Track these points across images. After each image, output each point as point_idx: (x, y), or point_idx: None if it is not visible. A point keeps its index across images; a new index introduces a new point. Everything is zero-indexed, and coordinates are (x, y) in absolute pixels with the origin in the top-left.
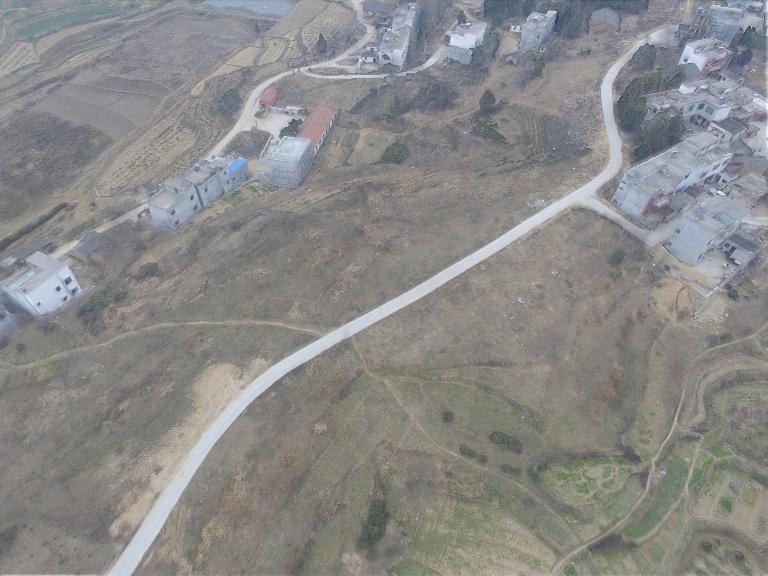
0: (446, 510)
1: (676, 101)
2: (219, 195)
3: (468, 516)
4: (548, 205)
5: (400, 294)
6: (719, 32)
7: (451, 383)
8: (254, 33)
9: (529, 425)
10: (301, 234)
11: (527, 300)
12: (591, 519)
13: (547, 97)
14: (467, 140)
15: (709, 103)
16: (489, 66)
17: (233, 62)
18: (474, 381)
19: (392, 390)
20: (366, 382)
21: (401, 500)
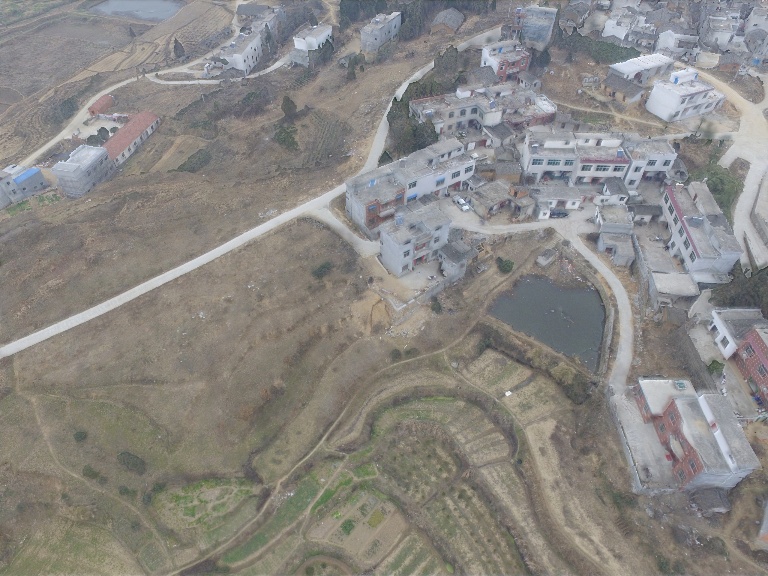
0: (56, 533)
1: (447, 106)
2: (7, 205)
3: (76, 539)
4: (277, 215)
5: (86, 309)
6: (531, 33)
7: (98, 402)
8: (130, 38)
9: (162, 445)
10: (39, 246)
11: (207, 315)
12: (193, 543)
13: (347, 102)
14: (264, 147)
15: (479, 108)
16: (322, 70)
17: (94, 68)
18: (121, 400)
19: (36, 409)
20: (11, 401)
21: (9, 523)
